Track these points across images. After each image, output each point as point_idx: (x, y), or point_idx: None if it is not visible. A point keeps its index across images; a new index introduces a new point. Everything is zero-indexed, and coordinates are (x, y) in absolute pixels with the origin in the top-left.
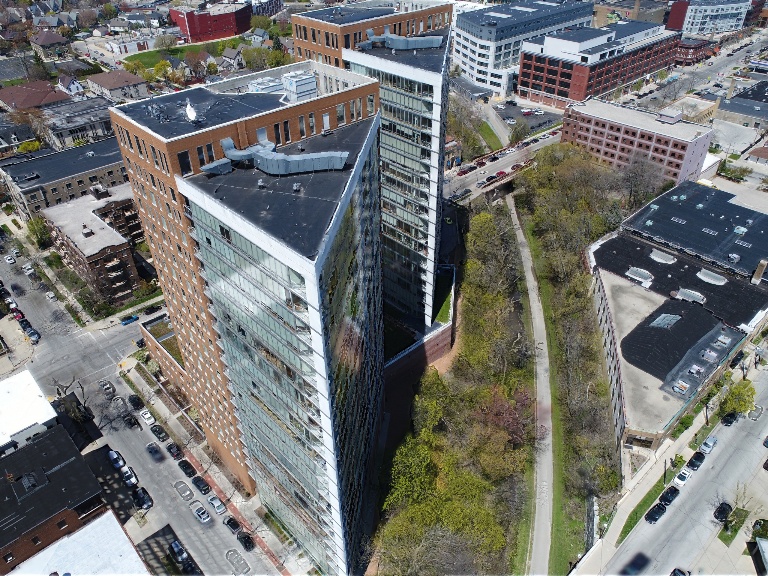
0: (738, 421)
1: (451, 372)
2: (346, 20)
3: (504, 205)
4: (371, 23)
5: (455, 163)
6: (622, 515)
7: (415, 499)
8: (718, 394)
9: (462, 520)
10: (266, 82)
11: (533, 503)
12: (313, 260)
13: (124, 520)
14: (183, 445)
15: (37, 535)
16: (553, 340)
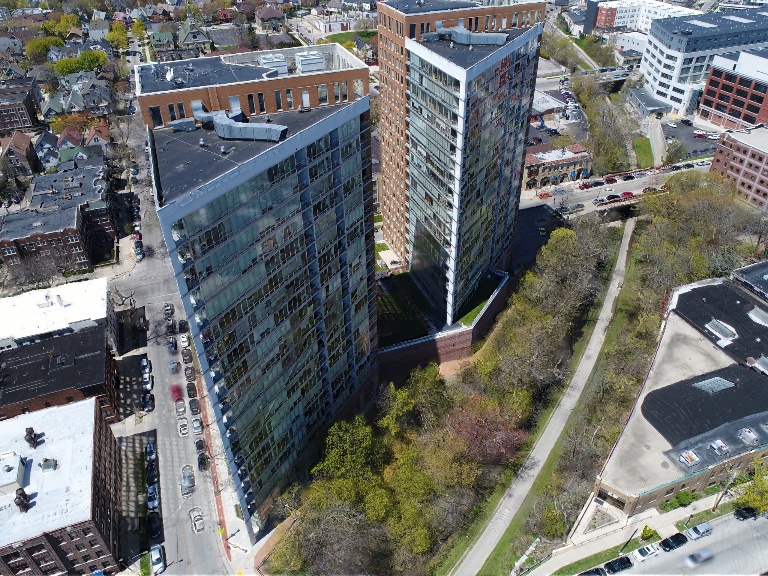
0: (757, 519)
1: (460, 376)
2: (418, 10)
3: (621, 228)
4: (442, 15)
5: (582, 175)
6: (553, 565)
7: (343, 474)
8: (749, 483)
9: (384, 509)
10: (272, 58)
11: (485, 525)
12: (161, 207)
13: (127, 415)
14: (199, 371)
15: (49, 401)
16: (597, 376)
